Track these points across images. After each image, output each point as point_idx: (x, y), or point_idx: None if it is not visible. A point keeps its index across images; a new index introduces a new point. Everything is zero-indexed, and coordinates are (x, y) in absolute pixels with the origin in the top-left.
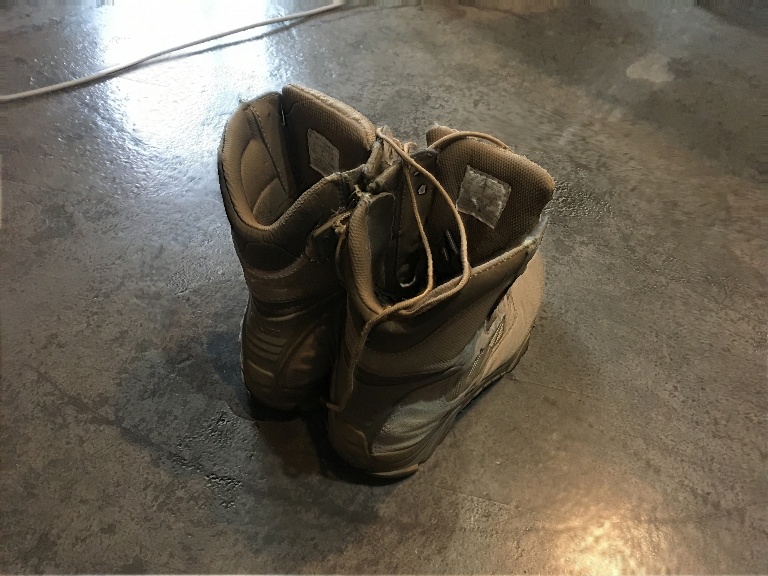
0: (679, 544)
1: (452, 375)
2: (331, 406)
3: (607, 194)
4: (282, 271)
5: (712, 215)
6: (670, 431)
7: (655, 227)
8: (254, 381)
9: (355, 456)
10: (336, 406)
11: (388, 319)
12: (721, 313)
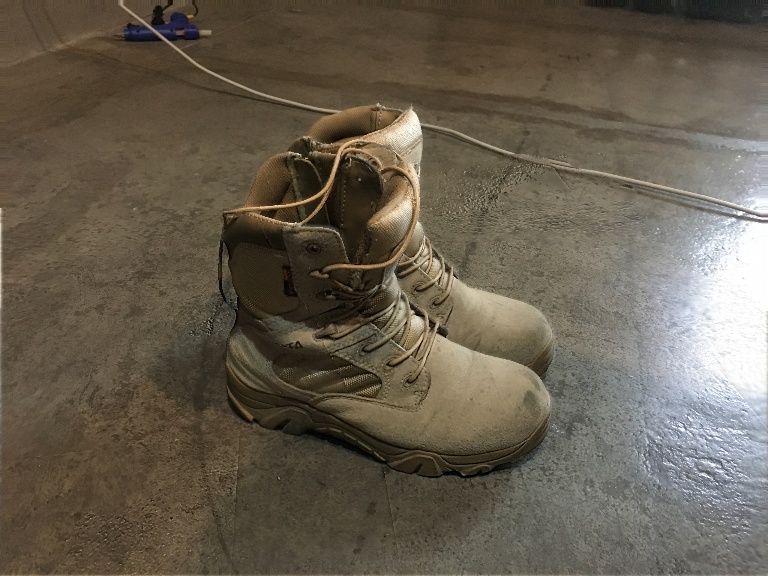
0: None
1: (263, 331)
2: None
3: None
4: None
5: None
6: None
7: None
8: None
9: None
10: None
11: None
12: None
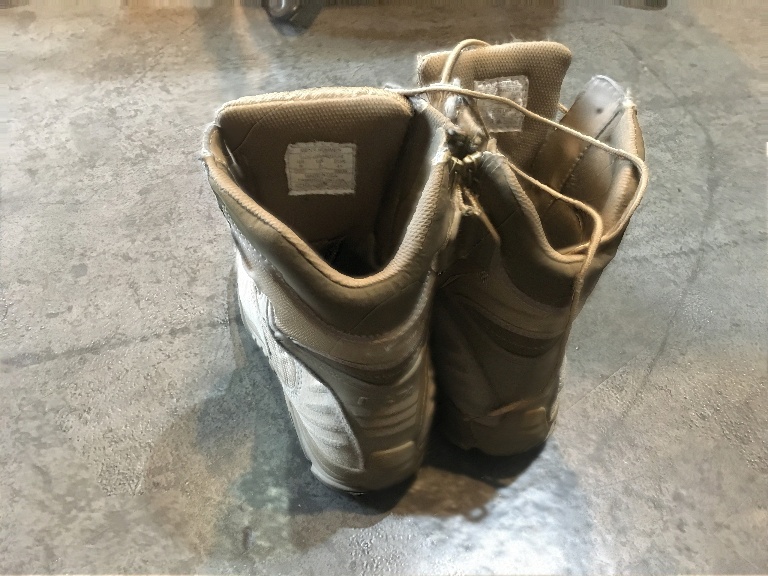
0: (712, 292)
1: None
2: (504, 410)
3: None
4: (415, 311)
5: None
6: None
7: None
8: (393, 468)
9: (534, 438)
10: (513, 405)
11: None
12: None
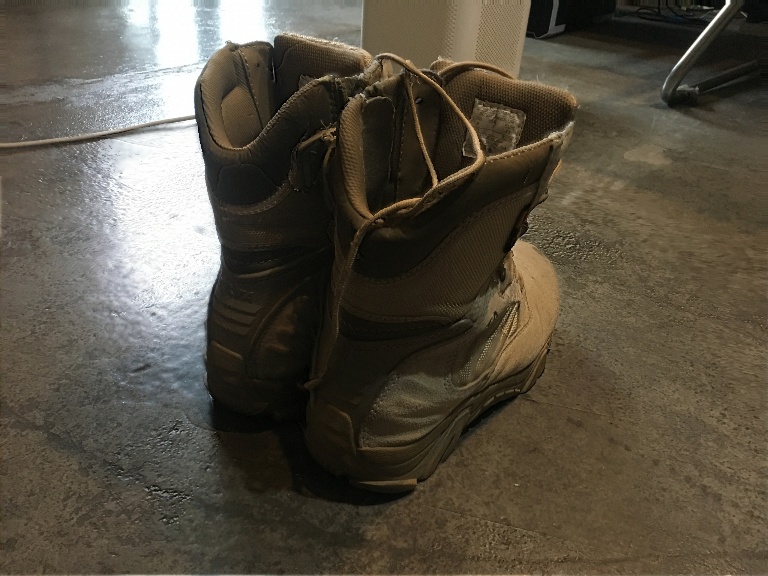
0: None
1: (461, 334)
2: (310, 382)
3: (617, 243)
4: (260, 204)
5: (732, 264)
6: (725, 458)
7: (673, 271)
8: (218, 368)
9: (337, 454)
10: (316, 379)
11: (384, 225)
12: (761, 347)
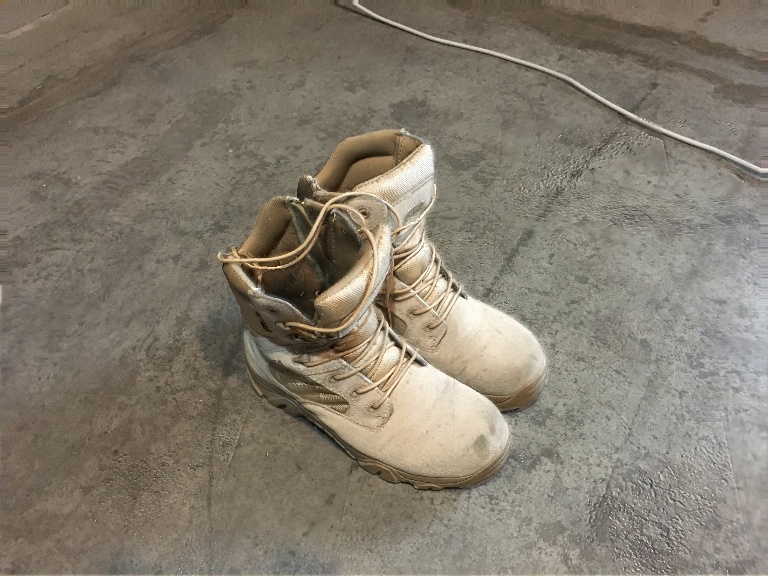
0: None
1: None
2: None
3: None
4: None
5: None
6: None
7: None
8: None
9: None
10: None
11: None
12: None
